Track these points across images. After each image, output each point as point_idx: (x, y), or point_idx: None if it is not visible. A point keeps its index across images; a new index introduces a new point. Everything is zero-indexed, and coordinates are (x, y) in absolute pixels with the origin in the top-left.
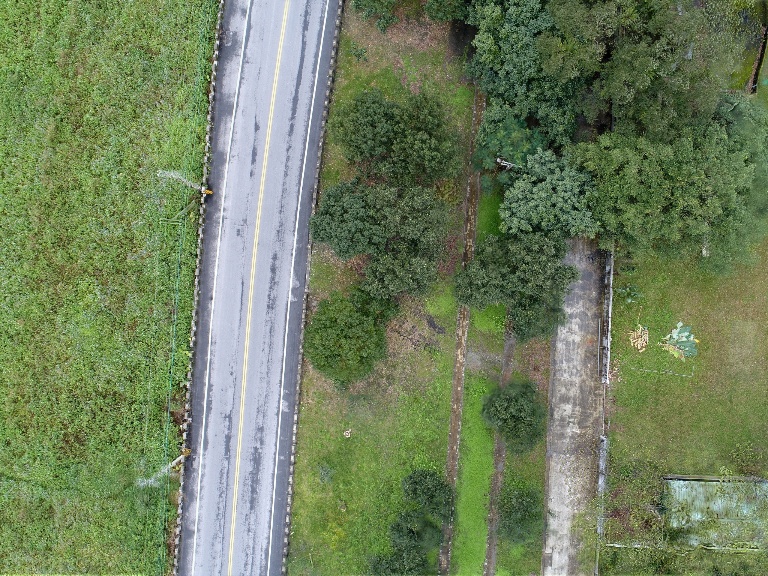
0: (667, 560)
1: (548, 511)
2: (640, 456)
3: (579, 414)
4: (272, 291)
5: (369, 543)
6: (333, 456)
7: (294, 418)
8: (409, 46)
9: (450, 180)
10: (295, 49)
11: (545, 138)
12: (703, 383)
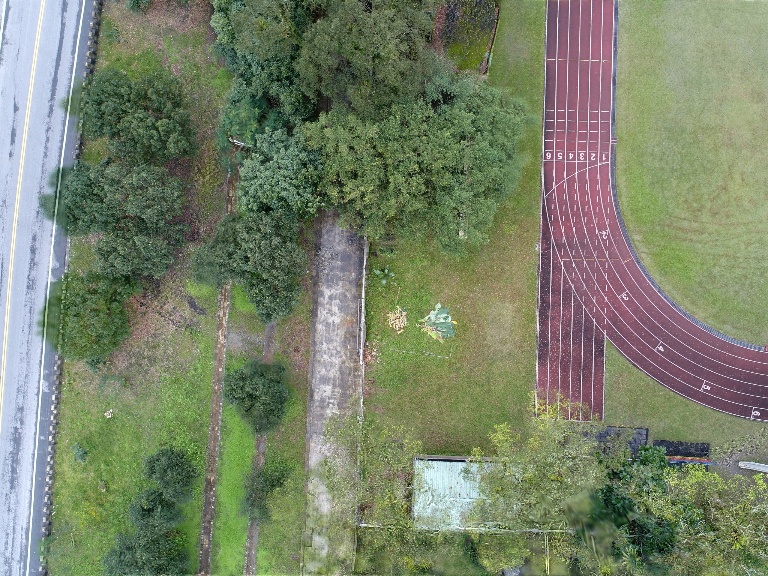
0: (418, 540)
1: (308, 492)
2: (399, 437)
3: (339, 395)
4: (32, 272)
5: (131, 523)
6: (94, 436)
7: (52, 398)
8: (170, 28)
9: (211, 162)
10: (54, 30)
11: (278, 118)
12: (461, 364)
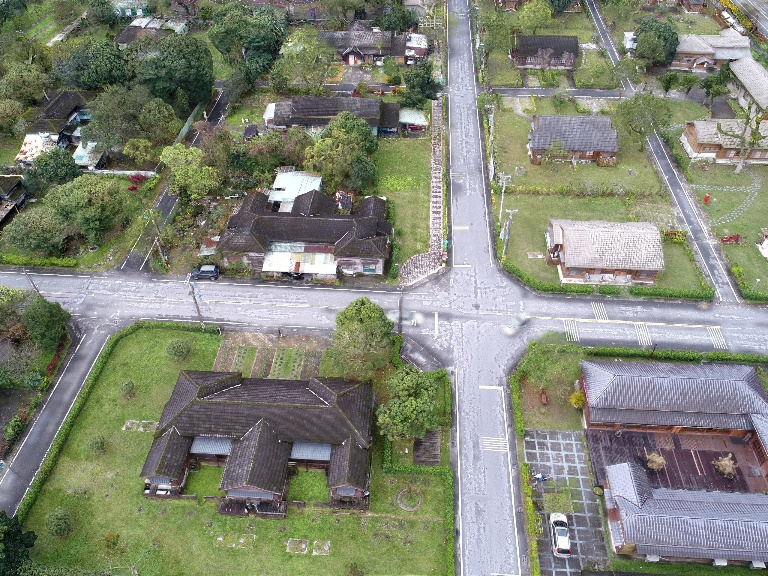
0: None
1: None
2: None
3: None
4: None
5: None
6: None
7: (5, 1)
8: None
9: None
10: None
11: None
12: None
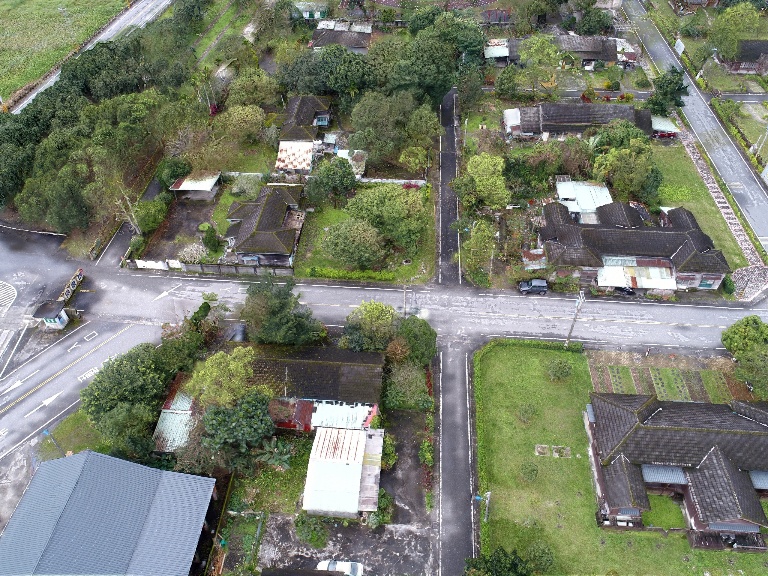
0: None
1: None
2: None
3: (270, 6)
4: None
5: None
6: None
7: (170, 2)
8: None
9: None
10: None
11: None
12: None
